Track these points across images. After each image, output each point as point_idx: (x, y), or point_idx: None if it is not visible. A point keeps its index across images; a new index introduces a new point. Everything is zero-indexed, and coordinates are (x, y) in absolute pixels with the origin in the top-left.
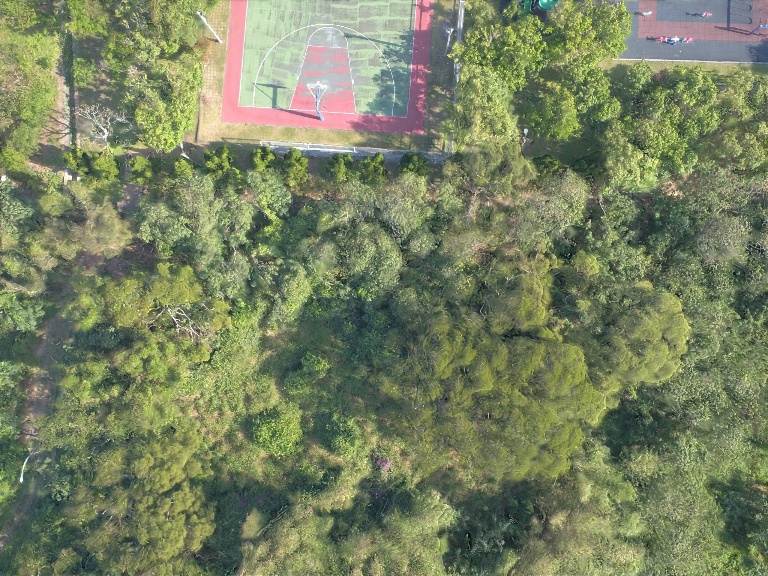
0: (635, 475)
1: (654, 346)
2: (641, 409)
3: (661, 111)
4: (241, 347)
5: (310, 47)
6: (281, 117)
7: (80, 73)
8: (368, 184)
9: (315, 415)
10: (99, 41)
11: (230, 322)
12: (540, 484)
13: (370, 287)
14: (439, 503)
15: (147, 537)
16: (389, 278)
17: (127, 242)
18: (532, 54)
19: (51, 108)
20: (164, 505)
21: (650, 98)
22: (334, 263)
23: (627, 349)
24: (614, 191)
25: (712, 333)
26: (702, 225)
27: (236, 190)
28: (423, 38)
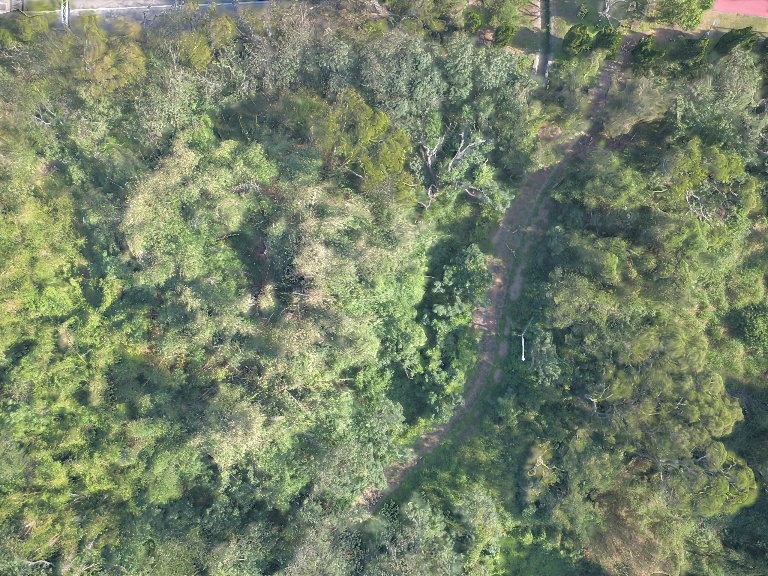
0: None
1: None
2: None
3: None
4: (732, 238)
5: None
6: None
7: None
8: None
9: None
10: None
11: None
12: None
13: None
14: None
15: (698, 414)
16: None
17: (659, 116)
18: None
19: None
20: (703, 385)
21: None
22: None
23: None
24: None
25: None
26: None
27: None
28: None
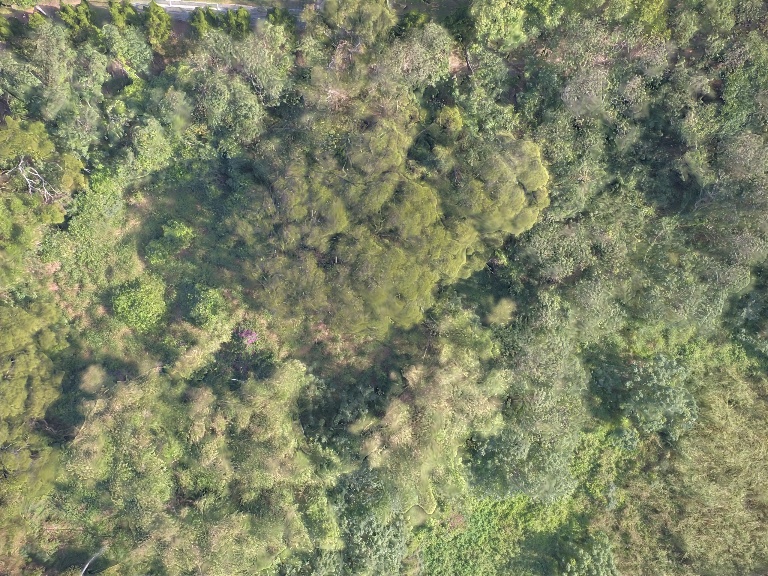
0: (506, 345)
1: (507, 187)
2: (511, 276)
3: None
4: (102, 215)
5: None
6: None
7: None
8: None
9: (179, 287)
10: None
11: (82, 179)
12: (411, 357)
13: (229, 144)
14: (301, 372)
15: None
16: (247, 132)
17: None
18: None
19: None
20: (4, 364)
21: None
22: (192, 119)
23: (479, 191)
24: (484, 51)
25: (575, 186)
26: (571, 84)
27: (96, 49)
28: None
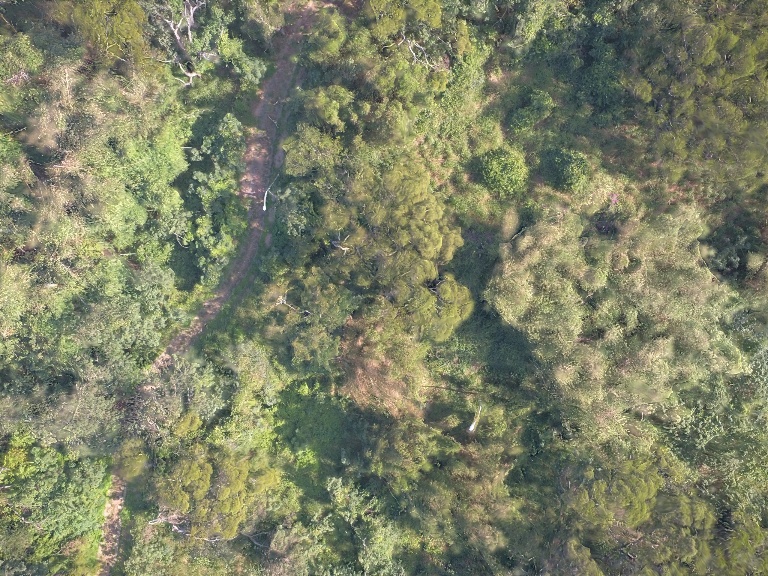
0: None
1: None
2: None
3: None
4: (467, 88)
5: None
6: None
7: None
8: None
9: (540, 154)
10: None
11: (470, 48)
12: (762, 214)
13: (606, 11)
14: None
15: (409, 237)
16: None
17: None
18: None
19: None
20: (419, 213)
21: None
22: None
23: None
24: None
25: None
26: None
27: None
28: None
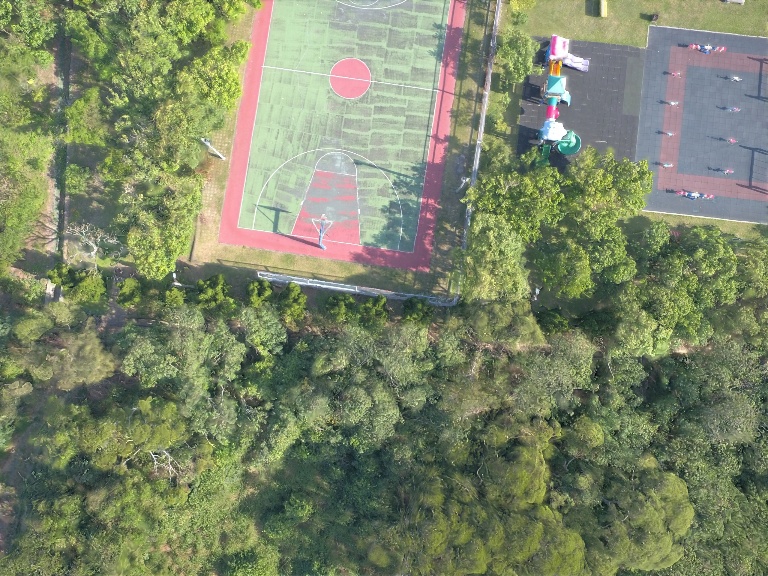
0: None
1: (659, 539)
2: None
3: (679, 280)
4: (222, 484)
5: (317, 171)
6: (281, 242)
7: (73, 180)
8: (368, 327)
9: (295, 560)
10: (95, 145)
11: (212, 465)
12: None
13: (363, 439)
14: None
15: None
16: (384, 433)
17: (108, 374)
18: (549, 208)
19: (39, 212)
20: None
21: (668, 263)
22: (327, 410)
23: (630, 540)
24: (624, 352)
25: (718, 518)
26: (713, 397)
27: (229, 320)
28: (436, 171)
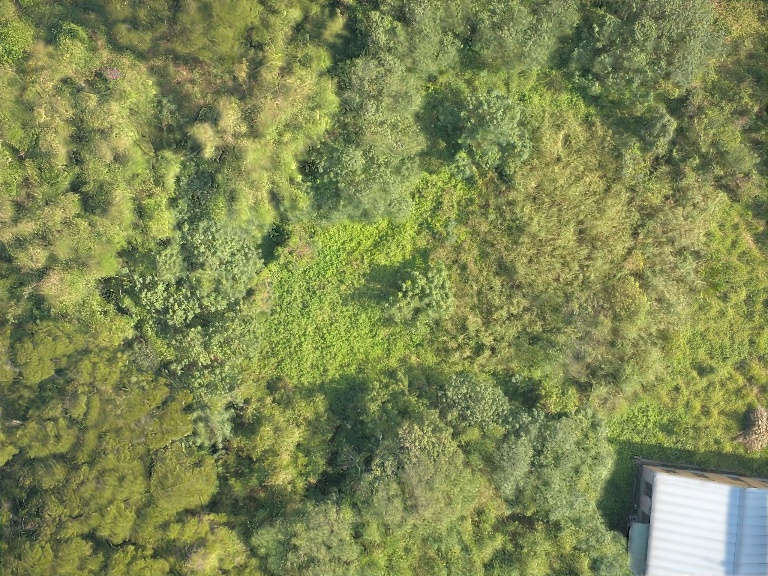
0: None
1: None
2: (357, 14)
3: None
4: None
5: None
6: None
7: None
8: None
9: (46, 27)
10: None
11: None
12: None
13: None
14: (154, 97)
15: None
16: None
17: None
18: None
19: None
20: None
21: None
22: None
23: None
24: None
25: None
26: None
27: None
28: None
